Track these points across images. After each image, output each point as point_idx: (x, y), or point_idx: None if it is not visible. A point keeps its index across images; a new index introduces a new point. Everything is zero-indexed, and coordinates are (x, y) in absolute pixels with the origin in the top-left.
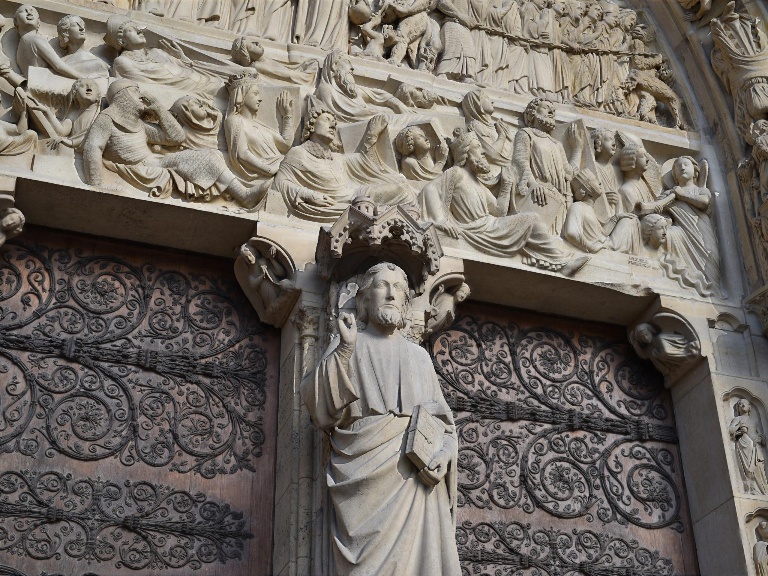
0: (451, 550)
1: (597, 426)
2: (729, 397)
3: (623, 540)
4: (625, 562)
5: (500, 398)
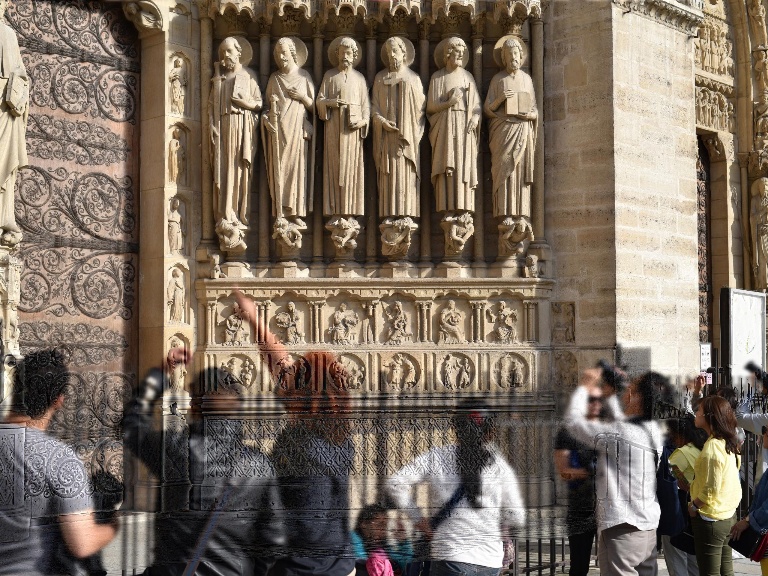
0: (24, 150)
1: (97, 60)
2: (173, 56)
3: (102, 128)
4: (102, 140)
5: (44, 39)
